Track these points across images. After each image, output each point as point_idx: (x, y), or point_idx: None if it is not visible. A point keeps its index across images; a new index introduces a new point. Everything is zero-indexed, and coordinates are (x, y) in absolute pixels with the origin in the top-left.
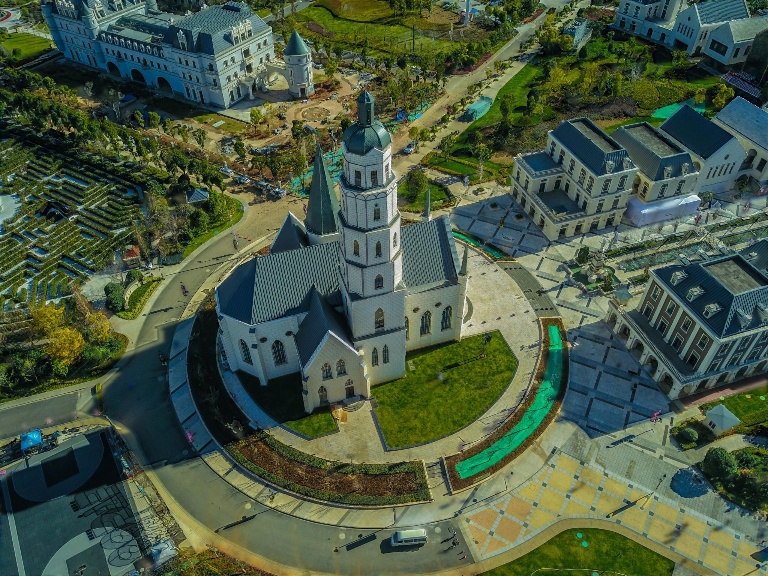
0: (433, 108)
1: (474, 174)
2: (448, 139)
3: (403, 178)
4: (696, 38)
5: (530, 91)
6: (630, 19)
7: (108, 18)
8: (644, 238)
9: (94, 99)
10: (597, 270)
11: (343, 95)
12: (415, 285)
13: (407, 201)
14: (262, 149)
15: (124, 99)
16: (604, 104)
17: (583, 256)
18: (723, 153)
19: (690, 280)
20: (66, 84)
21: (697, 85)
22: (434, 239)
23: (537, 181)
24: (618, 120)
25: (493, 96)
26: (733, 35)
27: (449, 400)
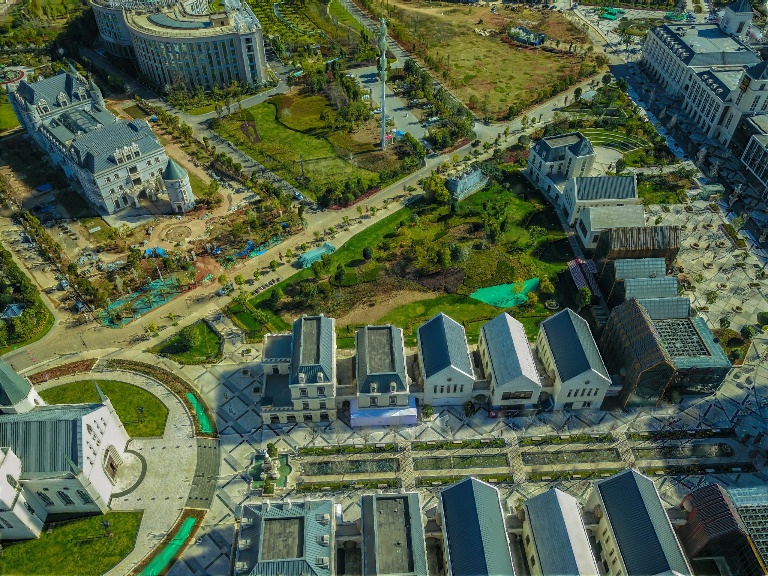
0: (280, 246)
1: (257, 331)
2: (242, 295)
3: (195, 323)
4: (573, 211)
5: (364, 248)
6: (536, 170)
7: (51, 113)
8: (346, 441)
9: (22, 183)
10: (268, 470)
11: (215, 216)
12: (43, 471)
13: (181, 349)
14: (108, 265)
15: (40, 189)
16: (433, 273)
17: (269, 451)
18: (443, 376)
19: (251, 529)
20: (13, 162)
21: (546, 265)
22: (67, 435)
23: (267, 366)
24: (434, 294)
25: (343, 241)
26: (591, 222)
27: (53, 571)
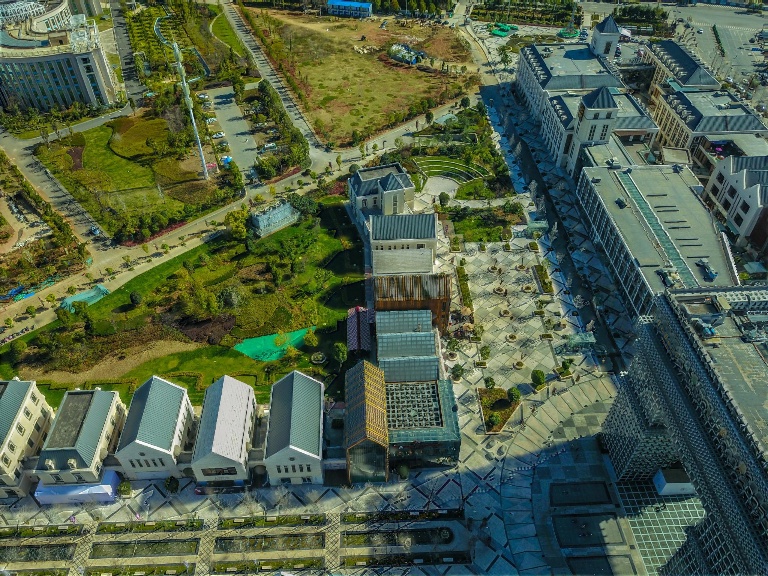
0: (52, 288)
1: None
2: None
3: None
4: None
5: None
6: (353, 204)
7: None
8: None
9: None
10: None
11: None
12: None
13: None
14: None
15: None
16: (202, 320)
17: None
18: (133, 451)
19: None
20: None
21: (329, 311)
22: None
23: None
24: (195, 345)
25: (122, 283)
26: (374, 266)
27: None
